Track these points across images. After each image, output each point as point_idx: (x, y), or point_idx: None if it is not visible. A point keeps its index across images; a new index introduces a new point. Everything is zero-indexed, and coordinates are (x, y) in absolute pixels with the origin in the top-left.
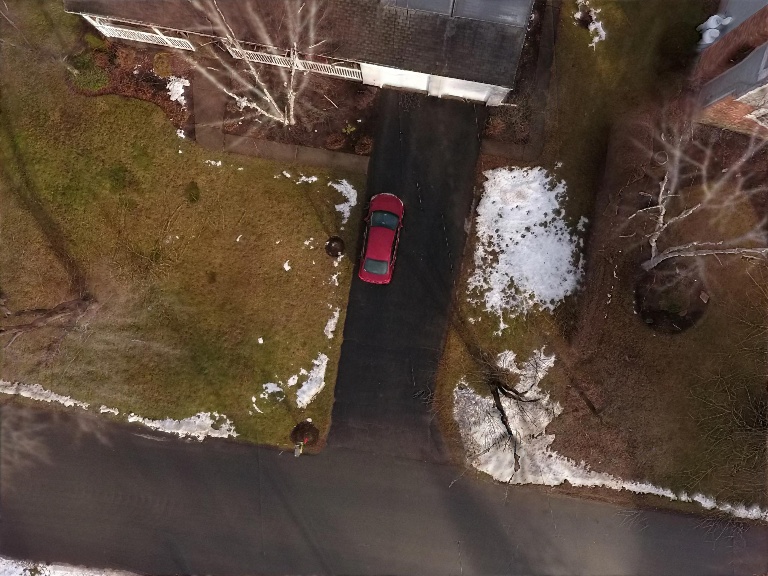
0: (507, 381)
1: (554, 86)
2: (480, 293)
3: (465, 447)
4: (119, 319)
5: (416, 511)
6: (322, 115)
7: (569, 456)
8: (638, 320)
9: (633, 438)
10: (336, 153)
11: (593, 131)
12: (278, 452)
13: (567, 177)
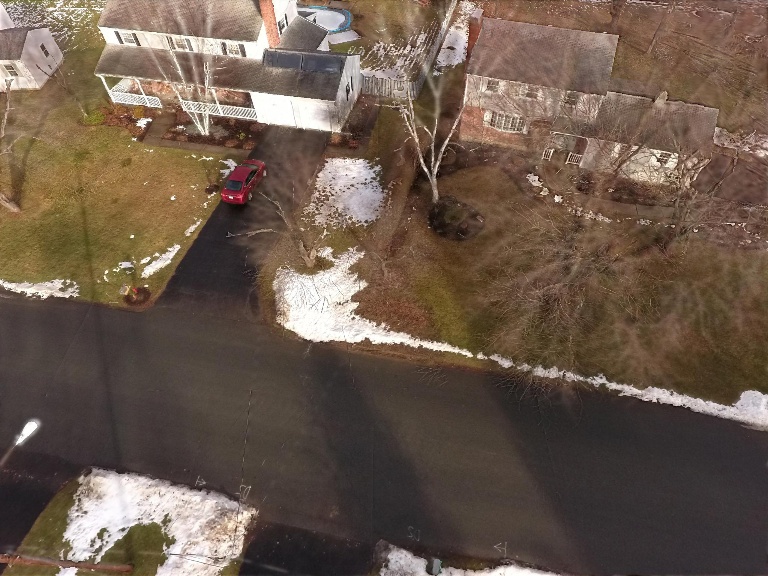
0: (323, 264)
1: (376, 128)
2: (312, 216)
3: (277, 308)
4: (30, 220)
5: (217, 361)
6: (227, 132)
7: (371, 318)
8: (431, 231)
9: (429, 307)
10: (230, 148)
11: None
12: (107, 309)
13: (382, 164)
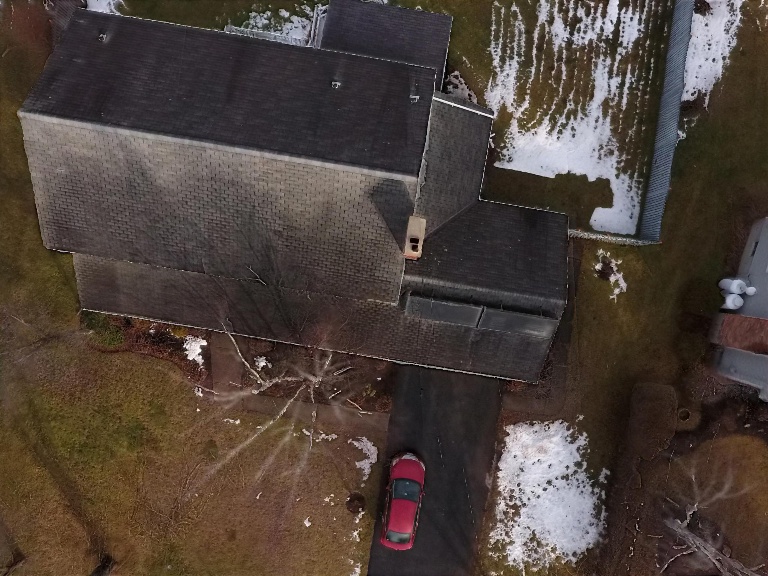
0: None
1: (575, 340)
2: (502, 546)
3: None
4: None
5: None
6: (342, 375)
7: None
8: (661, 573)
9: None
10: (356, 410)
11: (615, 383)
12: None
13: (589, 429)
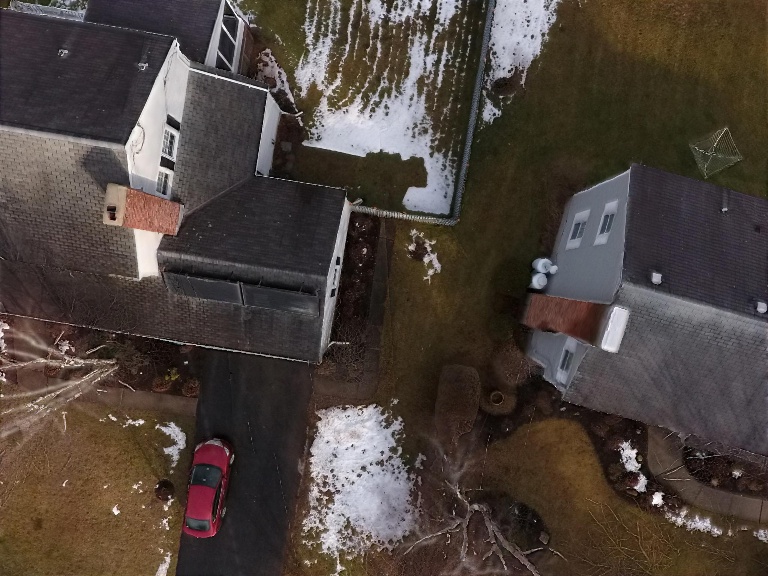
0: None
1: (388, 322)
2: (316, 534)
3: None
4: None
5: None
6: (146, 358)
7: None
8: (478, 561)
9: None
10: (163, 395)
11: (430, 366)
12: None
13: (404, 414)
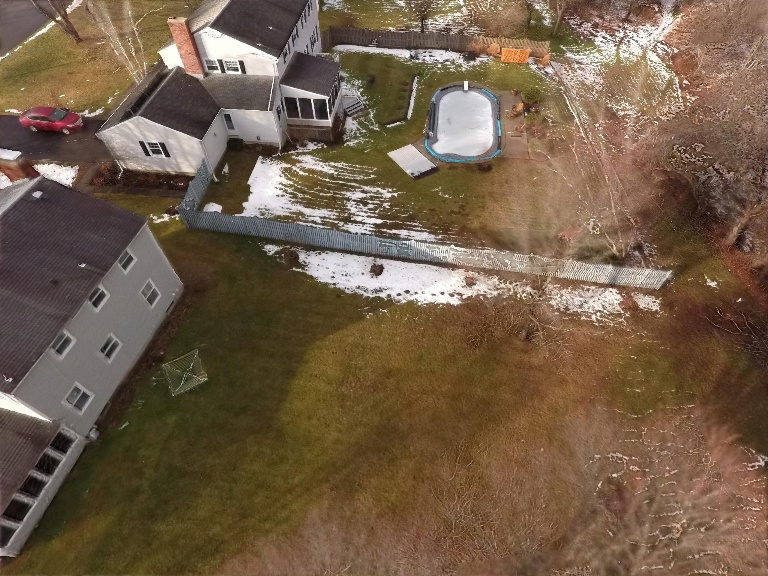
0: None
1: (126, 196)
2: None
3: None
4: (65, 49)
5: None
6: None
7: None
8: None
9: None
10: None
11: None
12: None
13: None
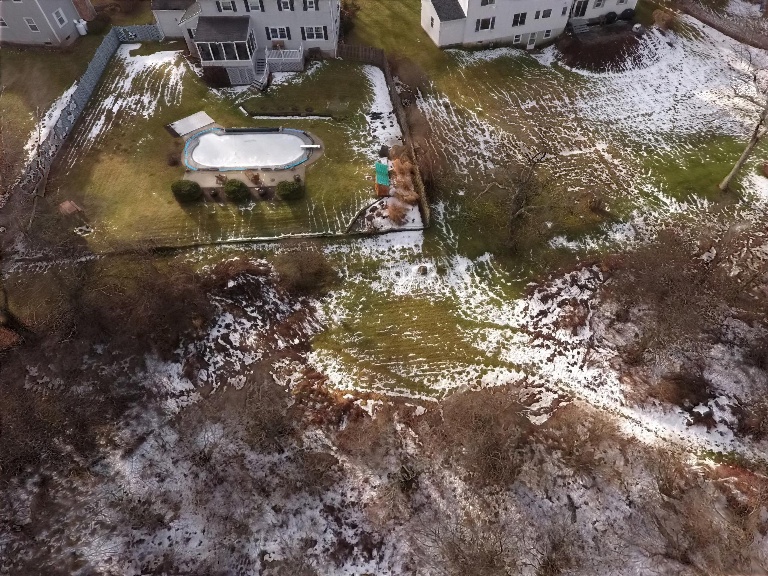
0: None
1: (154, 19)
2: None
3: None
4: None
5: None
6: None
7: None
8: None
9: None
10: None
11: None
12: None
13: None
